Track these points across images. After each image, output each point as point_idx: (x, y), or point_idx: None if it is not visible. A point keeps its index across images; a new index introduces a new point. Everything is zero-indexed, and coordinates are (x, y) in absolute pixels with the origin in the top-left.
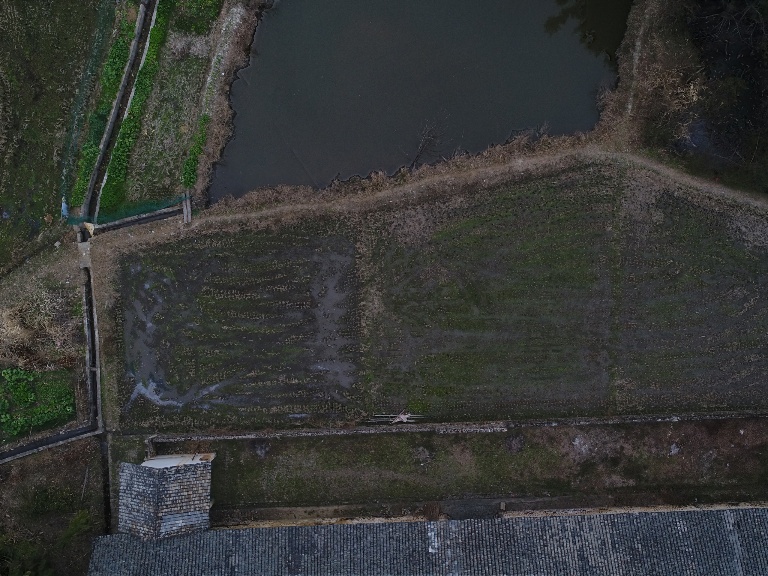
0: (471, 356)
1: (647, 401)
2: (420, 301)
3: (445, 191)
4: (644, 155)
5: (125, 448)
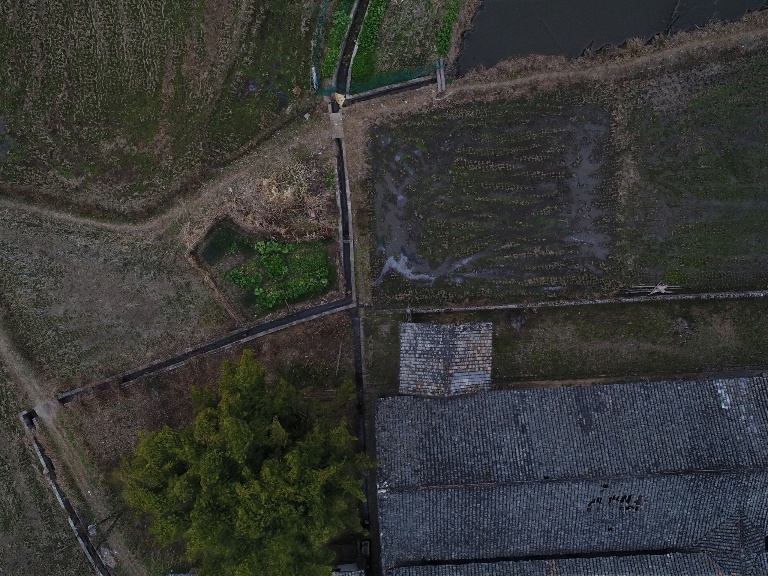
0: (729, 226)
1: None
2: (676, 170)
3: (702, 58)
4: None
5: (377, 323)
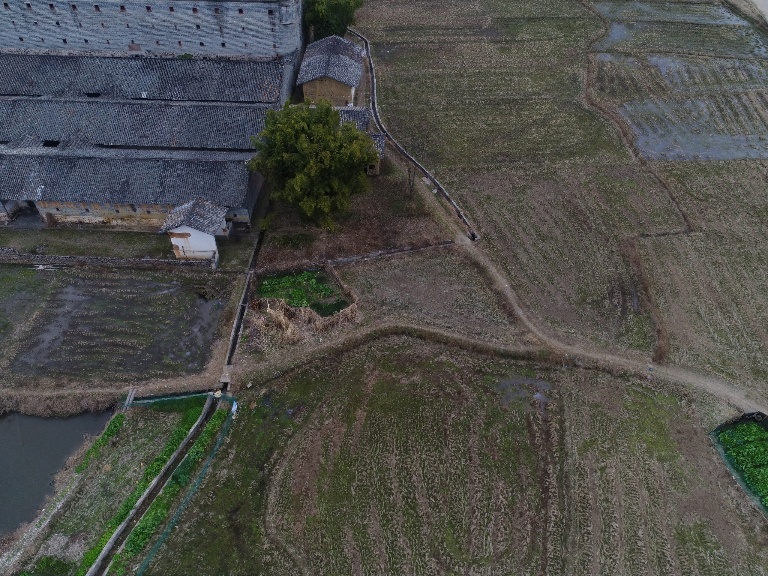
0: None
1: None
2: None
3: None
4: None
5: (238, 265)
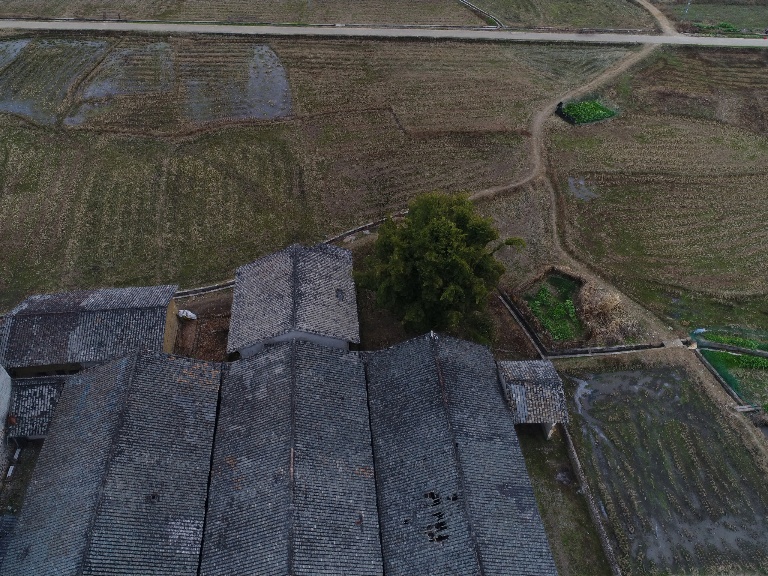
0: None
1: None
2: None
3: None
4: None
5: None
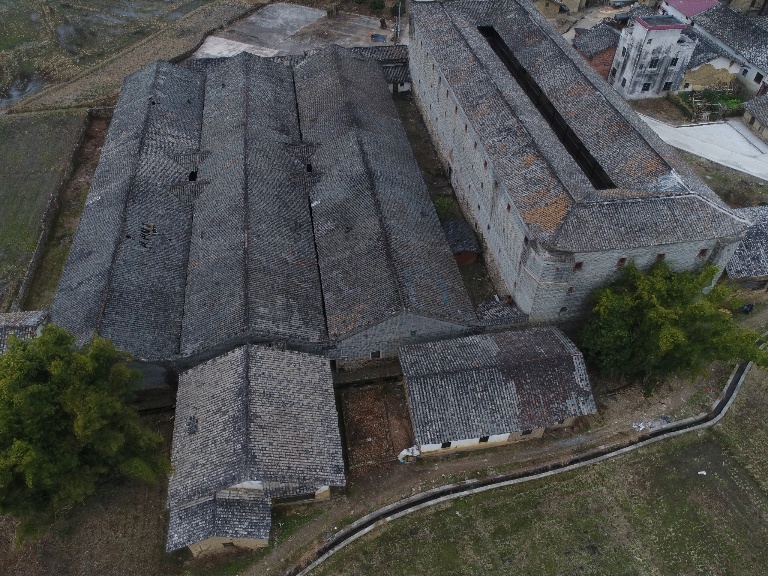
0: (7, 225)
1: (68, 159)
2: None
3: None
4: None
5: None
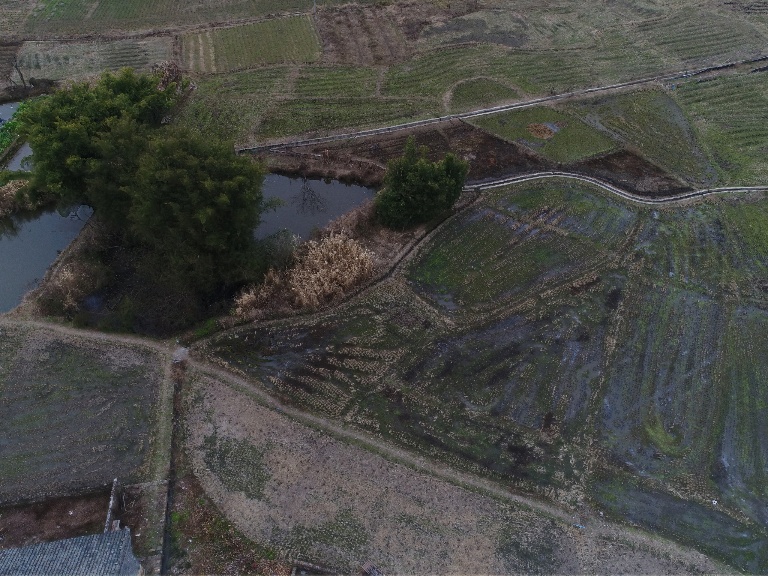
0: None
1: None
2: None
3: None
4: (44, 321)
5: None
